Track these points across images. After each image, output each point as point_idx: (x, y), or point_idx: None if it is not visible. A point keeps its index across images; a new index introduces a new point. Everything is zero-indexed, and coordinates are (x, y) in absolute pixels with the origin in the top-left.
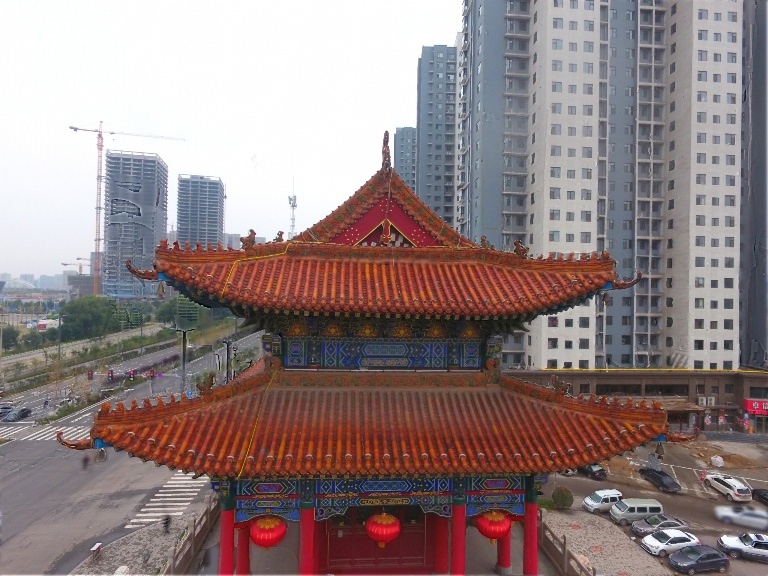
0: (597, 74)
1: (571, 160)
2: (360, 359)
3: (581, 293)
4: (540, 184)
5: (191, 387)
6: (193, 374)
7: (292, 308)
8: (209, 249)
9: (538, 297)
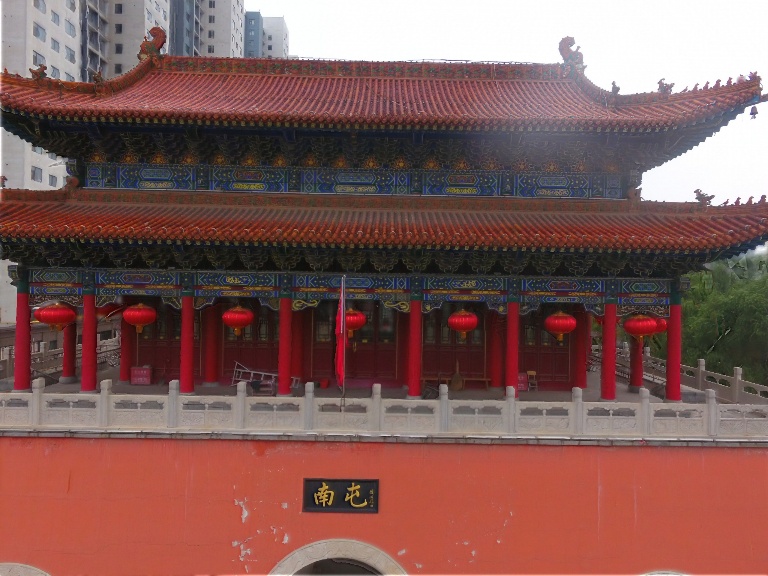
0: None
1: (54, 54)
2: None
3: None
4: (14, 66)
5: None
6: None
7: None
8: None
9: None
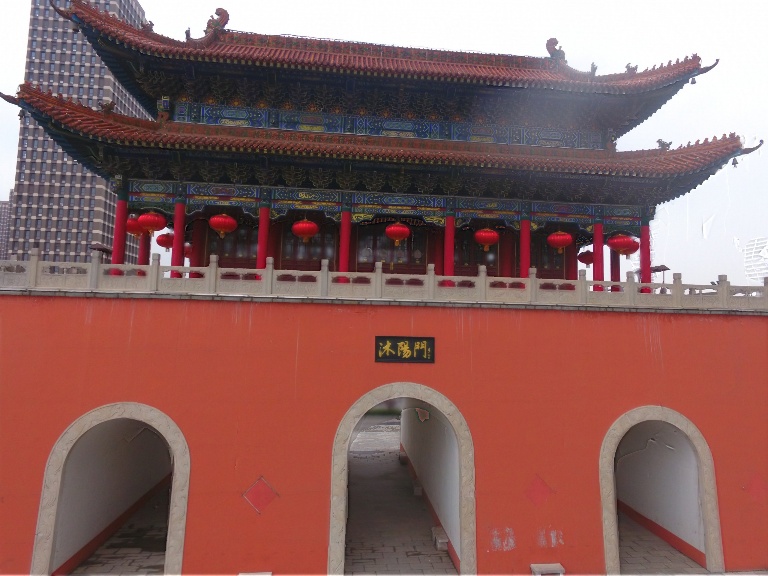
0: None
1: None
2: None
3: None
4: None
5: None
6: None
7: None
8: None
9: None
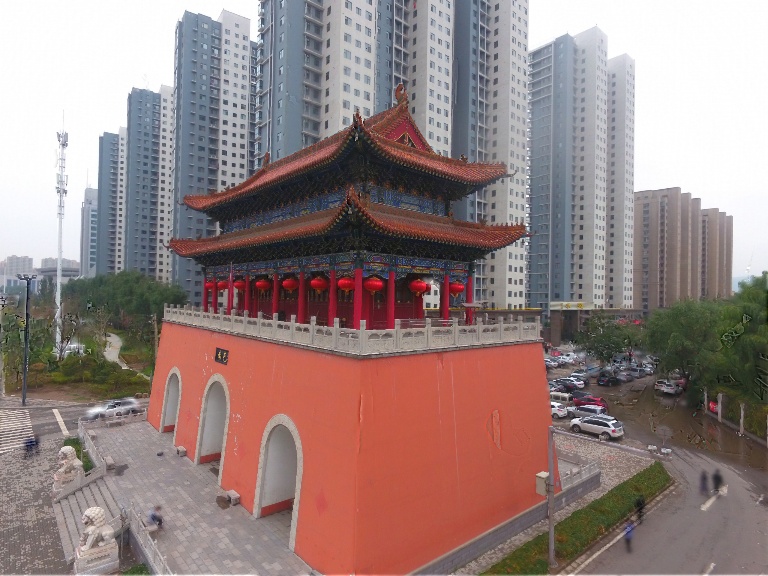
0: (372, 86)
1: None
2: (400, 203)
3: (496, 177)
4: None
5: None
6: None
7: (401, 160)
8: None
9: (481, 177)
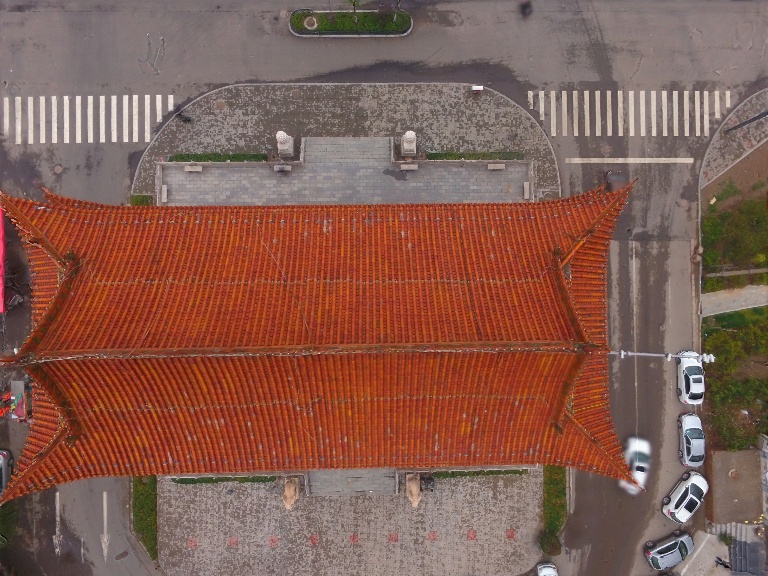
0: None
1: None
2: None
3: None
4: None
5: None
6: None
7: None
8: (16, 220)
9: None
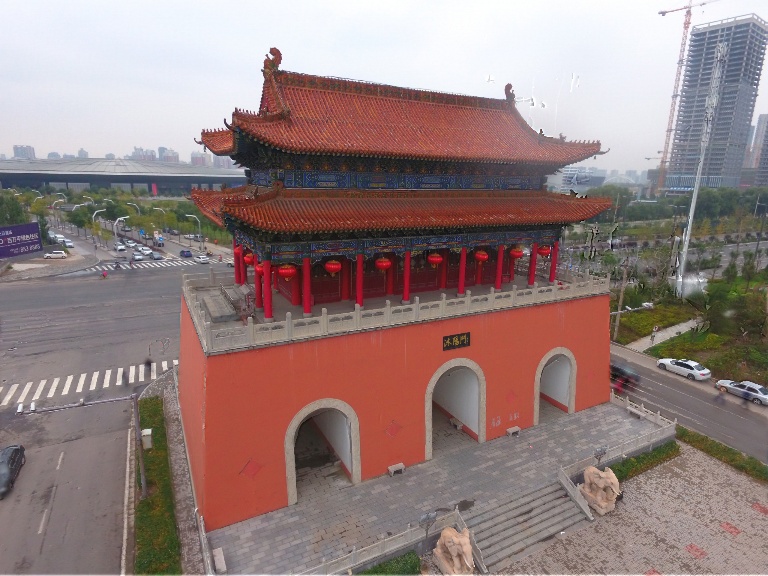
0: None
1: None
2: None
3: None
4: None
5: (572, 261)
6: (575, 250)
7: None
8: (219, 131)
9: None
